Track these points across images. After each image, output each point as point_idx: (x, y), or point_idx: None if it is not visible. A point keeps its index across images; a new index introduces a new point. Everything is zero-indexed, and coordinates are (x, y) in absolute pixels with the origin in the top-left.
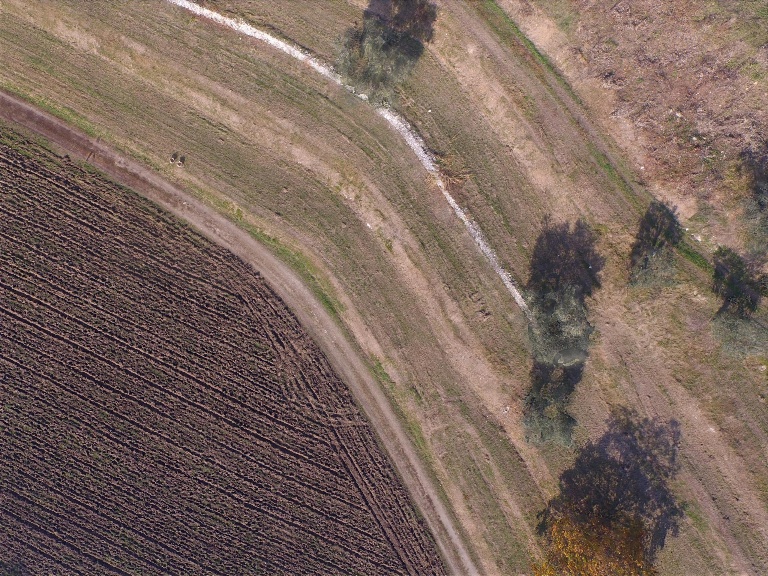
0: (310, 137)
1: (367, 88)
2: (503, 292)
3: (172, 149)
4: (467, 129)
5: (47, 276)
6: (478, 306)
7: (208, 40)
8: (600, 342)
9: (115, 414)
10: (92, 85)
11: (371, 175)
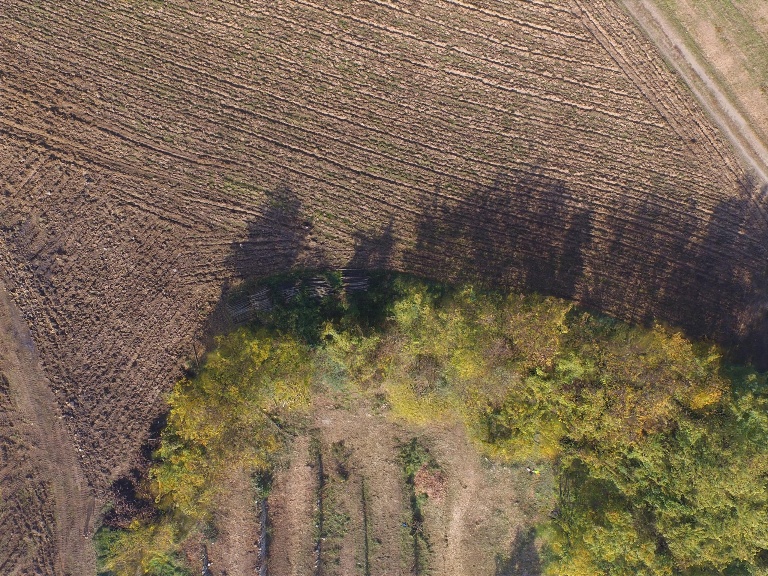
0: None
1: None
2: None
3: None
4: None
5: None
6: None
7: None
8: None
9: (354, 20)
10: None
11: None
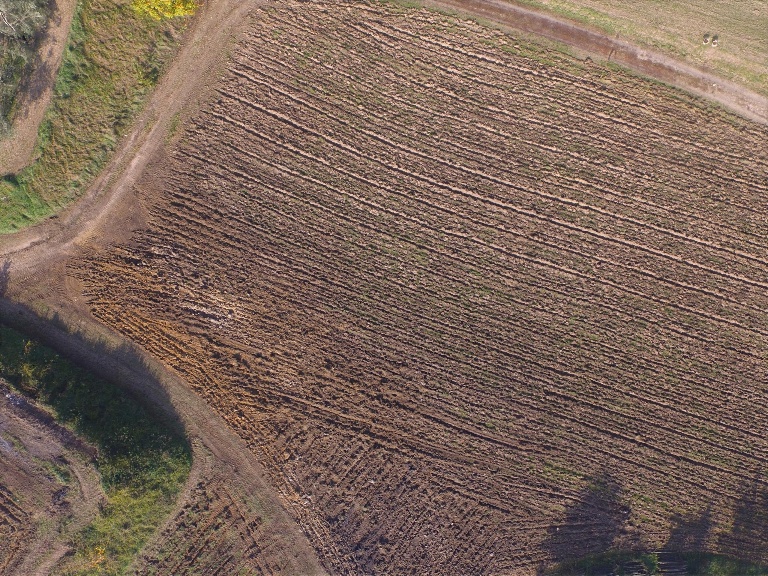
0: None
1: None
2: None
3: (703, 30)
4: None
5: (593, 181)
6: None
7: None
8: None
9: (680, 308)
10: None
11: None
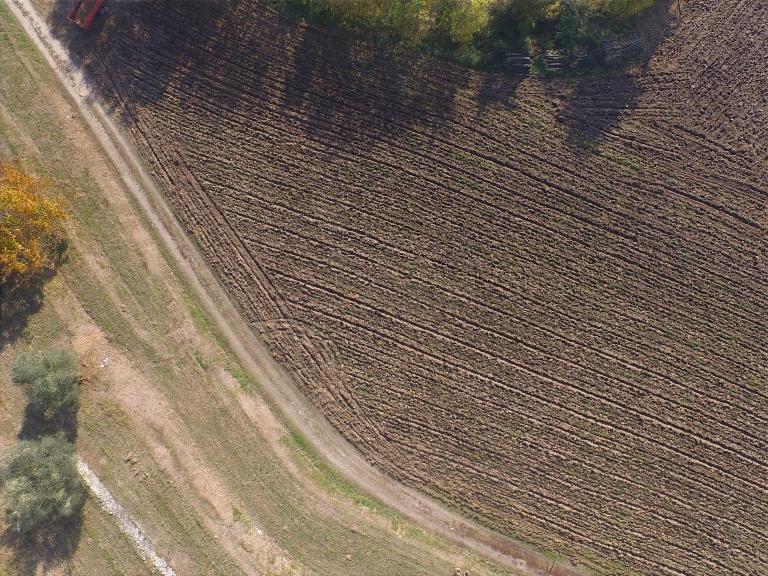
0: None
1: None
2: (113, 486)
3: None
4: None
5: (581, 443)
6: (138, 468)
7: None
8: (5, 453)
9: (501, 311)
10: None
11: None
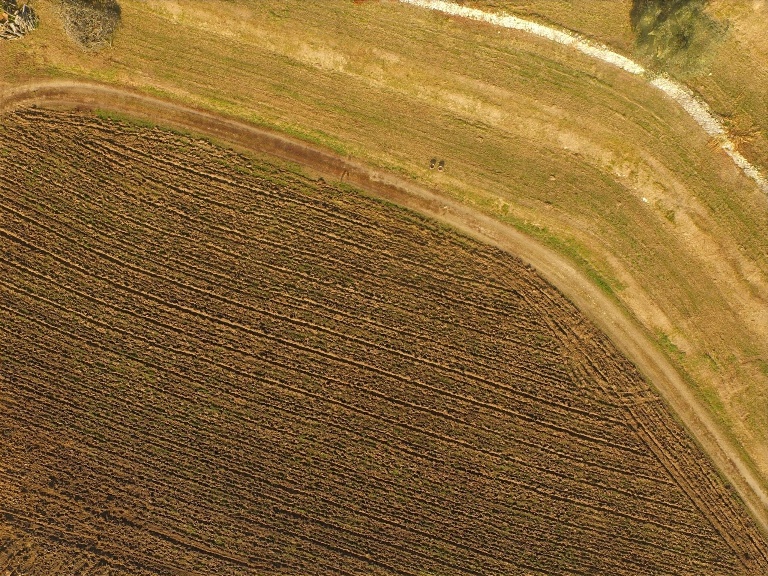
0: (581, 120)
1: (683, 57)
2: None
3: (429, 155)
4: (751, 86)
5: (322, 301)
6: None
7: (464, 39)
8: None
9: (409, 428)
10: (339, 103)
11: (650, 148)
